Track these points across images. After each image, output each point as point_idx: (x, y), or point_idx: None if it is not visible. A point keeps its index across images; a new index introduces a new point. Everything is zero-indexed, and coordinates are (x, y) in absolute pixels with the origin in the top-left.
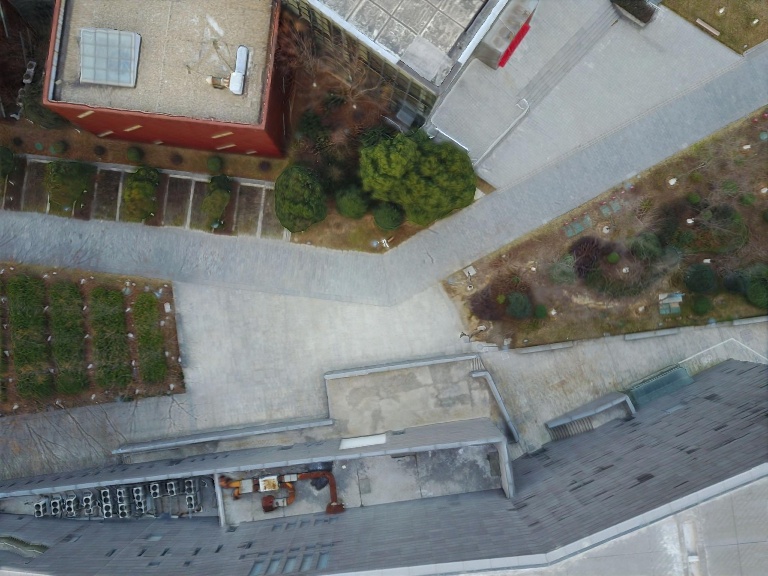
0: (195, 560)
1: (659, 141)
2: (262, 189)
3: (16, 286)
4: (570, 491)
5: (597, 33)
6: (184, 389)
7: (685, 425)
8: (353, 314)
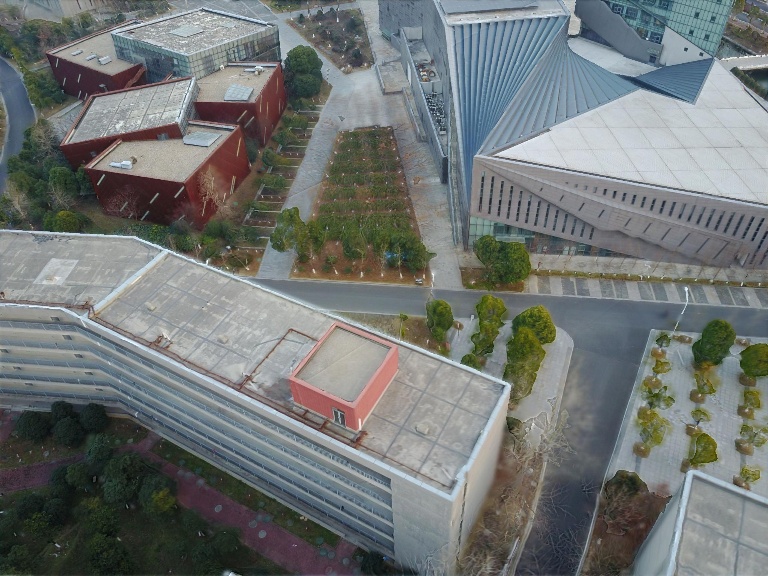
0: (443, 49)
1: (298, 41)
2: None
3: (336, 167)
4: (414, 4)
5: None
6: None
7: (395, 1)
8: None
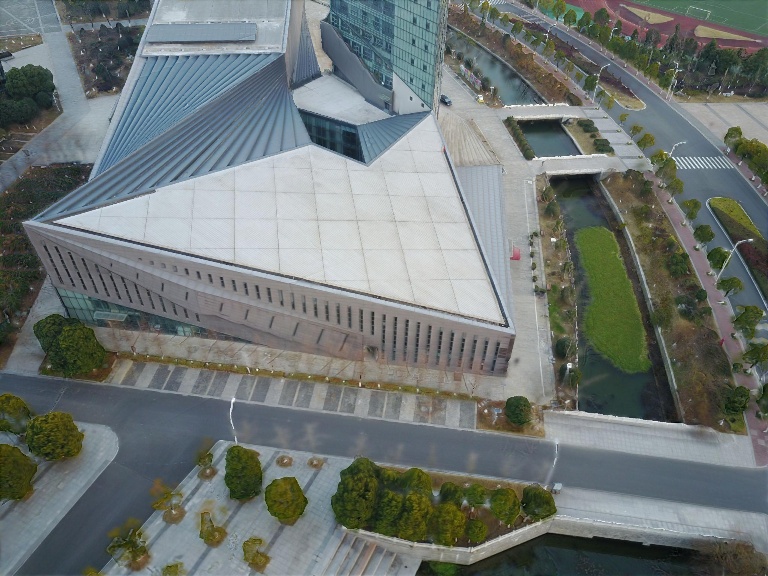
0: None
1: (64, 57)
2: (4, 140)
3: None
4: None
5: (7, 65)
6: (92, 164)
7: None
8: (87, 119)
